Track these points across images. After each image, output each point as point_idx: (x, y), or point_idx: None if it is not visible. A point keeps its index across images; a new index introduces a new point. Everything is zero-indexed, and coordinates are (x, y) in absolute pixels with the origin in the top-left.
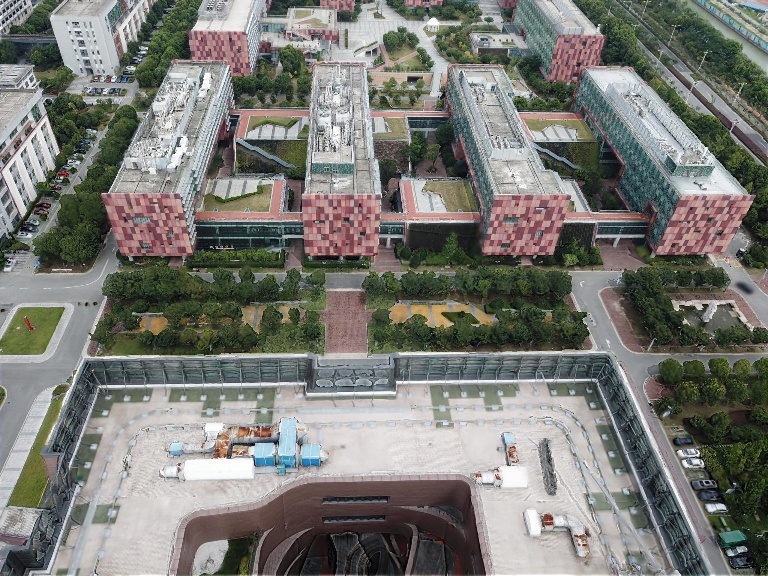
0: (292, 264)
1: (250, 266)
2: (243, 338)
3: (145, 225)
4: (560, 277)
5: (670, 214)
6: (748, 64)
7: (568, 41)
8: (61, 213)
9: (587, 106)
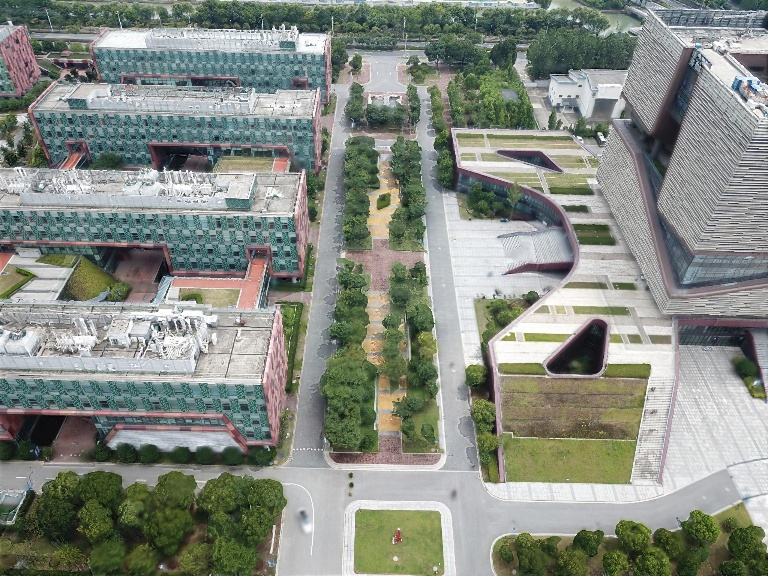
0: (298, 299)
1: (298, 331)
2: (431, 312)
3: (277, 378)
4: (362, 138)
5: (322, 71)
6: (75, 4)
7: (7, 46)
8: (171, 535)
9: (133, 72)
